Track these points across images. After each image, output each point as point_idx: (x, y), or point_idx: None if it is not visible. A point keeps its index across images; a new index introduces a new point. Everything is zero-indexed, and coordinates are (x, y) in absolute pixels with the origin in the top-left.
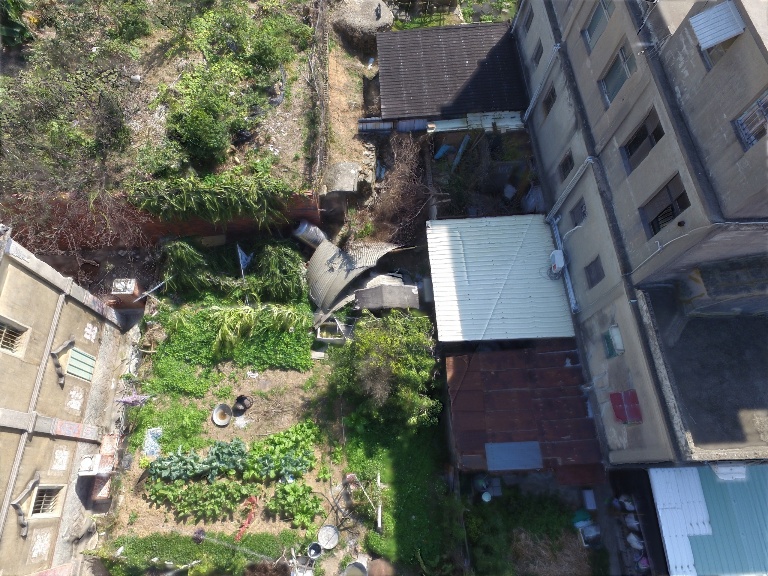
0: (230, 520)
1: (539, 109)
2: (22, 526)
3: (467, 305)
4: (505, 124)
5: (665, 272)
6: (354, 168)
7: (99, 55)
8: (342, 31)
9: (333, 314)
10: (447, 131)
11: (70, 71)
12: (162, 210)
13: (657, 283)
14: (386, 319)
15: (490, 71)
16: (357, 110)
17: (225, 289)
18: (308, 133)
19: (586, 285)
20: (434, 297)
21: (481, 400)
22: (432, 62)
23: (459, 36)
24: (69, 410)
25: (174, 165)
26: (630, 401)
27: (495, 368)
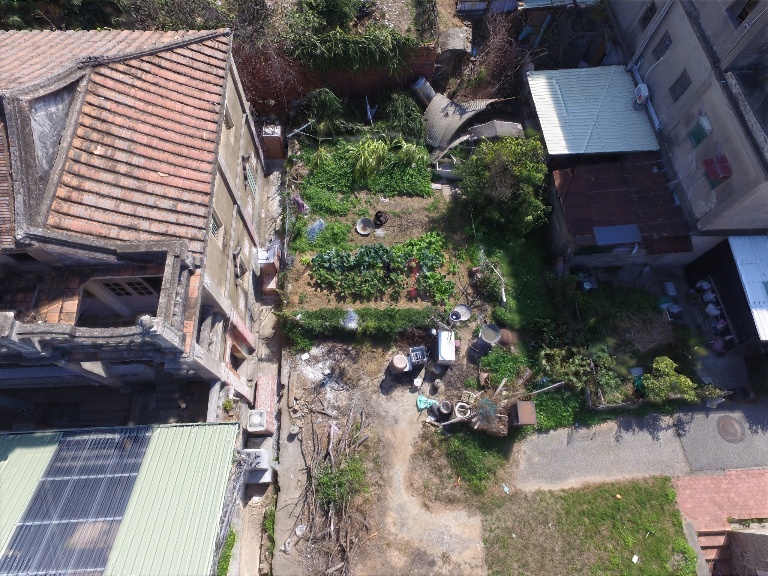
0: (381, 301)
1: None
2: (236, 277)
3: (568, 129)
4: (584, 1)
5: (750, 51)
6: (462, 32)
7: None
8: None
9: (450, 150)
10: (534, 8)
11: None
12: (312, 58)
13: (741, 69)
14: None
15: None
16: None
17: (357, 133)
18: (416, 11)
19: (671, 101)
20: (541, 124)
21: (586, 199)
22: None
23: None
24: (248, 212)
25: None
26: (721, 162)
27: (595, 176)
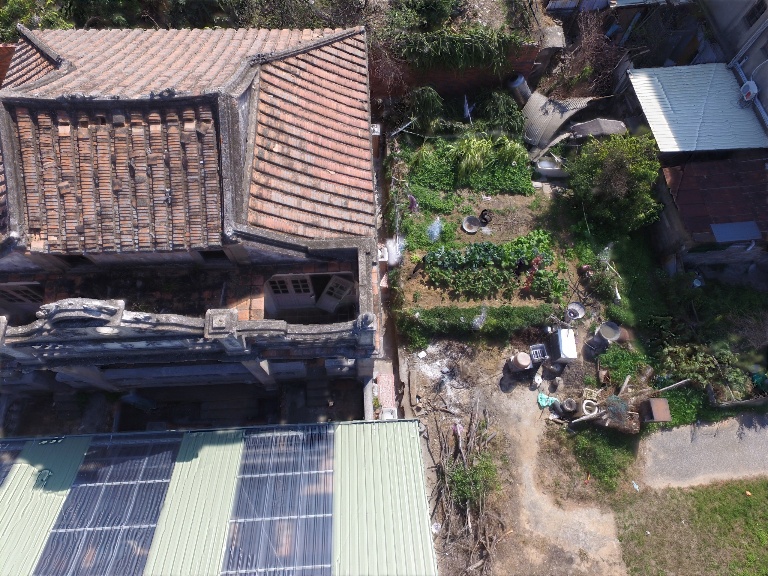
0: (494, 299)
1: None
2: None
3: (677, 127)
4: None
5: None
6: (560, 31)
7: None
8: None
9: (551, 148)
10: (626, 6)
11: None
12: (418, 56)
13: None
14: (608, 142)
15: None
16: None
17: (456, 131)
18: (508, 10)
19: None
20: (648, 122)
21: (699, 196)
22: None
23: None
24: None
25: (404, 32)
26: None
27: (706, 174)
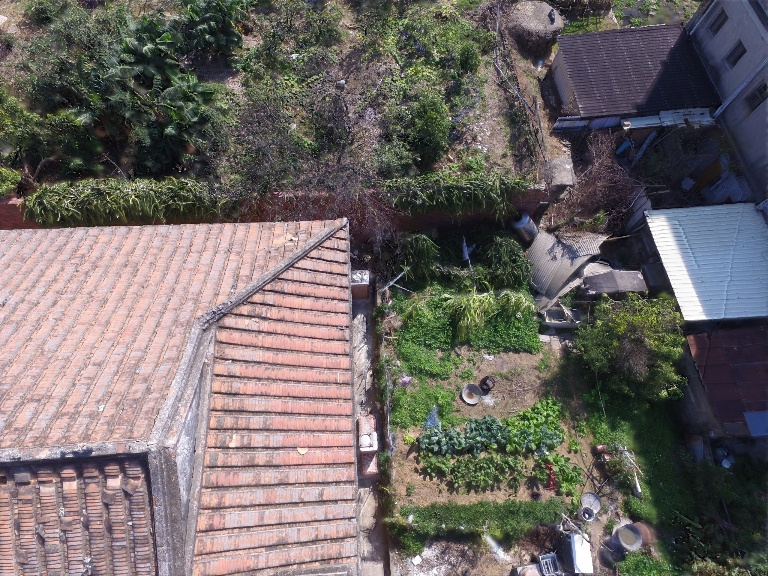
0: (498, 490)
1: (737, 105)
2: None
3: (702, 287)
4: (697, 120)
5: None
6: (568, 163)
7: (308, 62)
8: (517, 35)
9: (559, 299)
10: (641, 128)
11: (278, 77)
12: (410, 205)
13: None
14: (624, 302)
15: (674, 71)
16: (540, 110)
17: (454, 278)
18: (510, 132)
19: None
20: (670, 280)
21: (729, 373)
22: (616, 63)
23: (636, 39)
24: None
25: None
26: None
27: (736, 344)
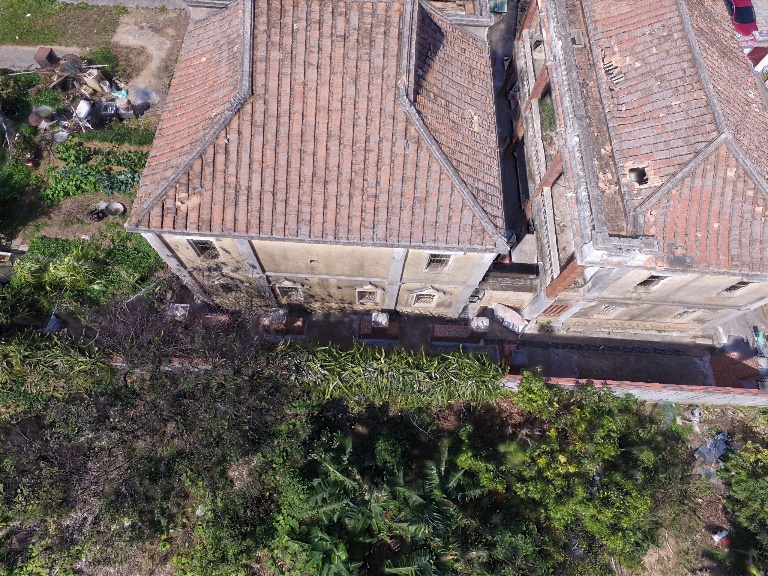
0: None
1: None
2: None
3: None
4: None
5: None
6: None
7: None
8: None
9: None
10: None
11: None
12: None
13: None
14: None
15: None
16: None
17: None
18: None
19: None
20: None
21: None
22: None
23: None
24: None
25: None
26: None
27: None
